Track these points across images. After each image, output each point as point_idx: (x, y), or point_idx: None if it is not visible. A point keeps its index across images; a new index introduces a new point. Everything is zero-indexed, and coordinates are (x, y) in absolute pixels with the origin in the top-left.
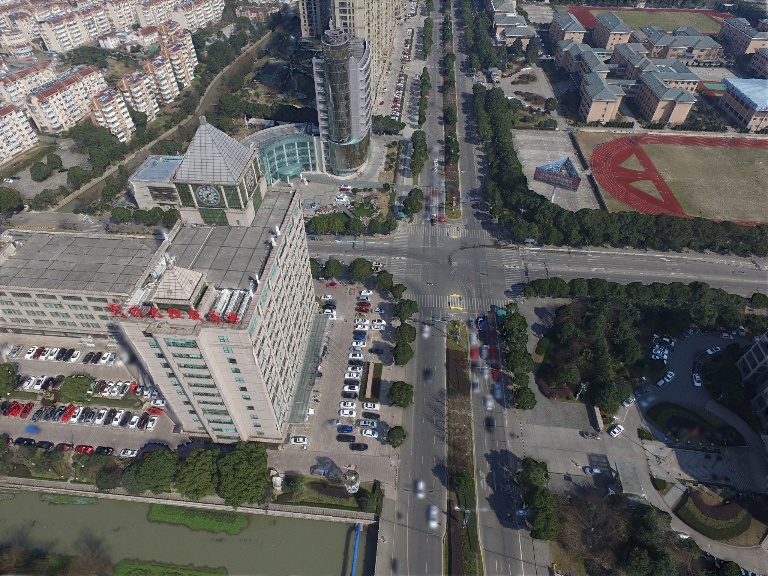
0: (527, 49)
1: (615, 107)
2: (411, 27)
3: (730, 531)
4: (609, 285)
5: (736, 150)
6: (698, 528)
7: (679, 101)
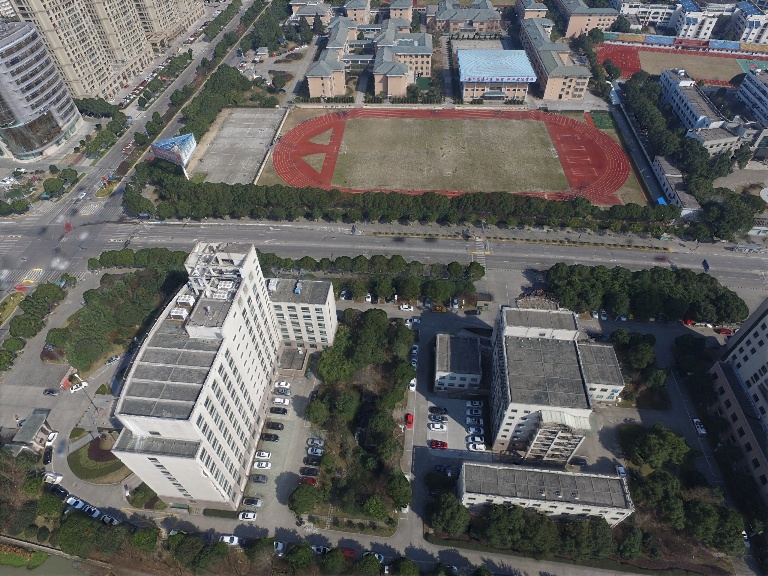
0: (313, 27)
1: (340, 83)
2: (224, 9)
3: (100, 471)
4: (172, 254)
5: (435, 121)
6: (74, 469)
7: (388, 74)
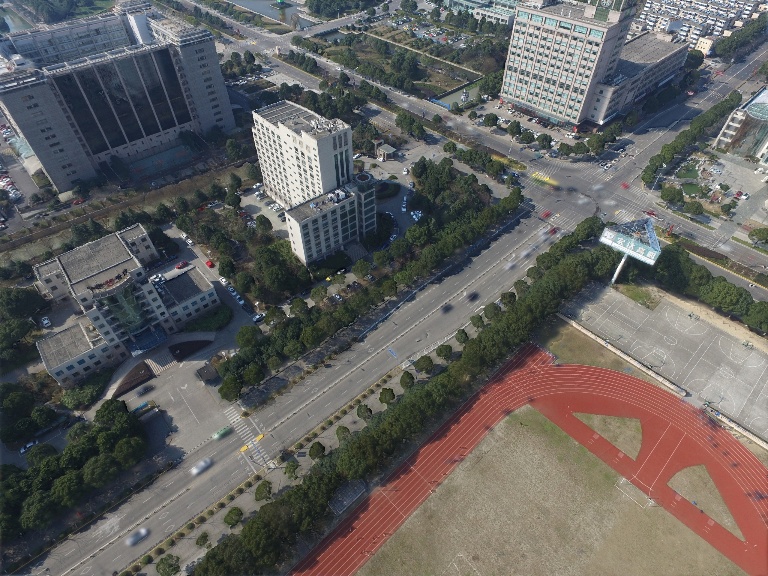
0: None
1: None
2: None
3: None
4: None
5: None
6: None
7: None
